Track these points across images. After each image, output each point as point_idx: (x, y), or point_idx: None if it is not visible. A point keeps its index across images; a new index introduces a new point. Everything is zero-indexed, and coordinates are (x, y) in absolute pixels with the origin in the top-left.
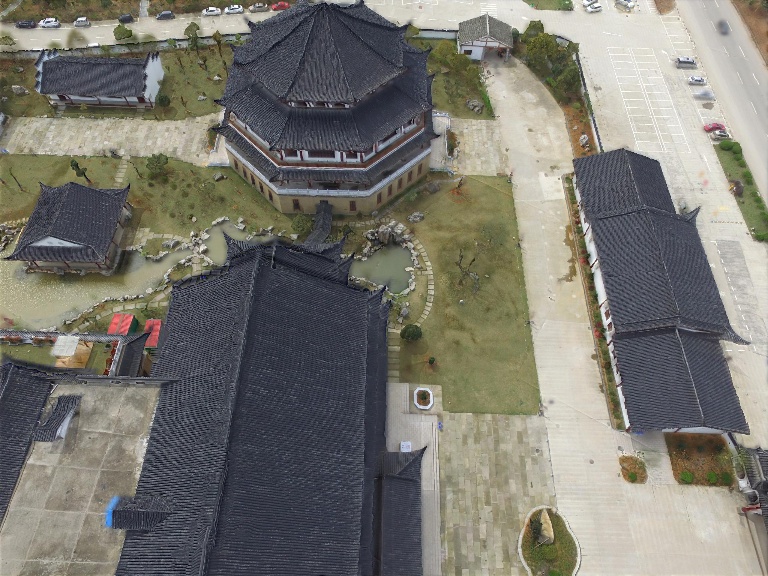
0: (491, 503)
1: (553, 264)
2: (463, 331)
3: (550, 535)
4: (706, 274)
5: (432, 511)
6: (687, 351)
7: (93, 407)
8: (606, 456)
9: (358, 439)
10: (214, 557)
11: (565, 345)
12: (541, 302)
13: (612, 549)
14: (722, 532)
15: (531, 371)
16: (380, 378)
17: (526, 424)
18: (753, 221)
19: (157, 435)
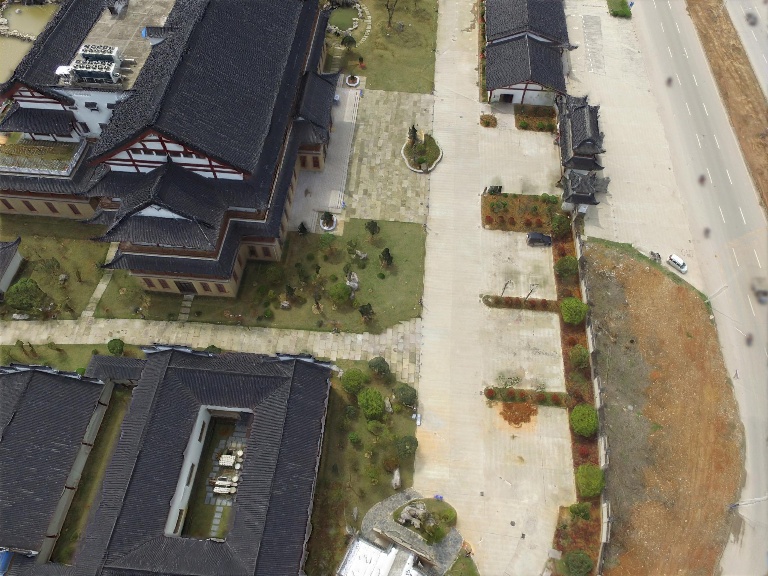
0: (388, 131)
1: (460, 22)
2: (387, 51)
3: (422, 139)
4: (559, 15)
5: (348, 131)
6: (532, 48)
7: (136, 4)
8: (472, 115)
9: (292, 27)
10: (200, 25)
11: (458, 63)
12: (446, 41)
13: (464, 155)
14: (540, 152)
15: (430, 73)
16: (319, 42)
17: (421, 98)
18: (614, 6)
19: (173, 14)
